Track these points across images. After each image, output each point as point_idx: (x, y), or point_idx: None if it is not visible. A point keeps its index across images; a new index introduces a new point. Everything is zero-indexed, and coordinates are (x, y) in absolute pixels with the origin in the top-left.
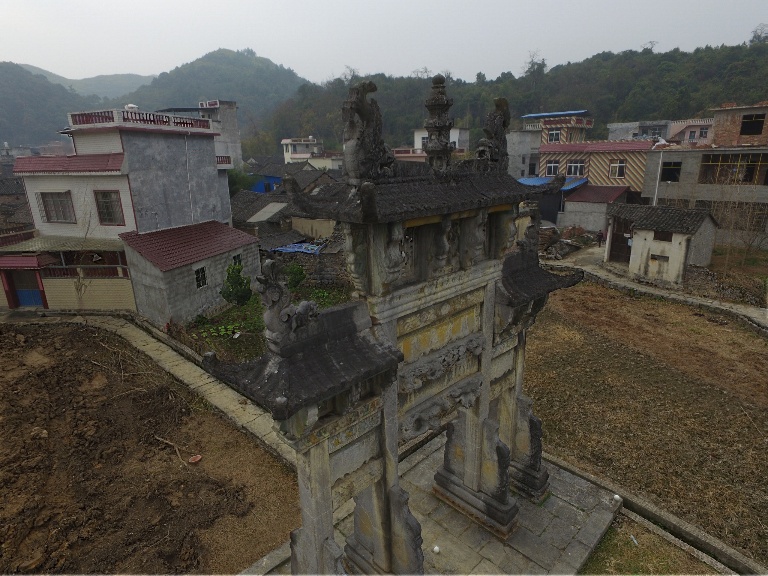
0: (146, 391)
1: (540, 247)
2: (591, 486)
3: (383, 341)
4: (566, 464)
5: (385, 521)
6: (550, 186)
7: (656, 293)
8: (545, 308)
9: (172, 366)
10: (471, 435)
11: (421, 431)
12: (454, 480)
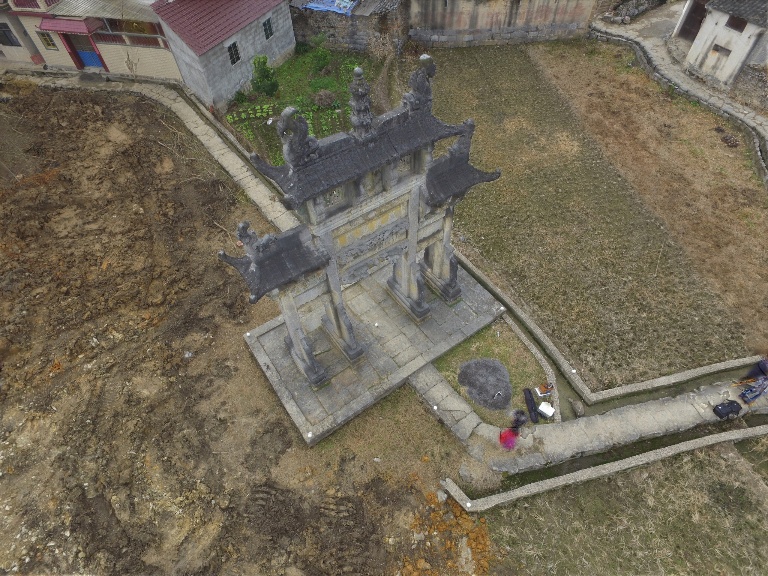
0: (203, 180)
1: (605, 9)
2: (491, 298)
3: (319, 247)
4: (486, 279)
5: (335, 318)
6: (461, 129)
7: (697, 94)
8: (566, 105)
9: (219, 155)
10: (404, 269)
11: (355, 280)
12: (396, 287)
